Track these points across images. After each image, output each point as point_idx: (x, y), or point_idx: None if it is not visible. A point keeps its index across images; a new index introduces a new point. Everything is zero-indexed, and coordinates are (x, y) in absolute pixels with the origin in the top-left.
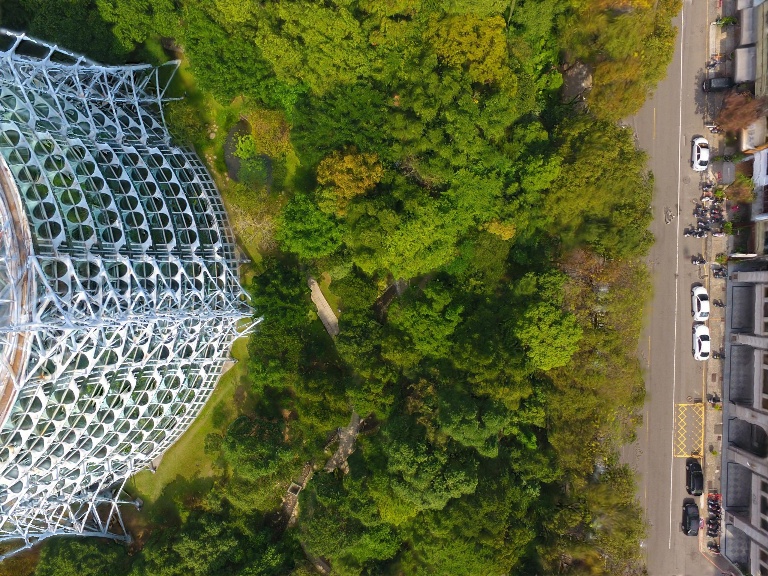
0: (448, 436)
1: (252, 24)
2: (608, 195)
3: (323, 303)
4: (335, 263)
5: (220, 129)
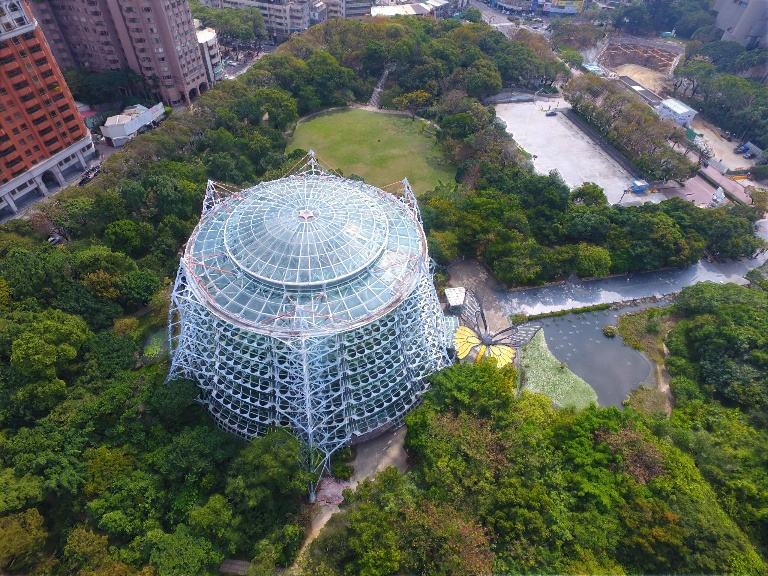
0: None
1: None
2: (5, 235)
3: None
4: None
5: (159, 364)
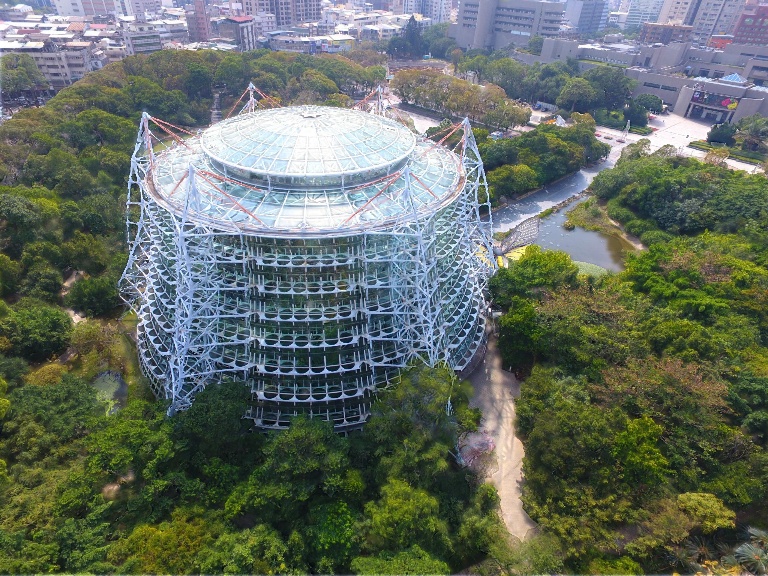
0: None
1: (6, 442)
2: None
3: (74, 318)
4: None
5: None
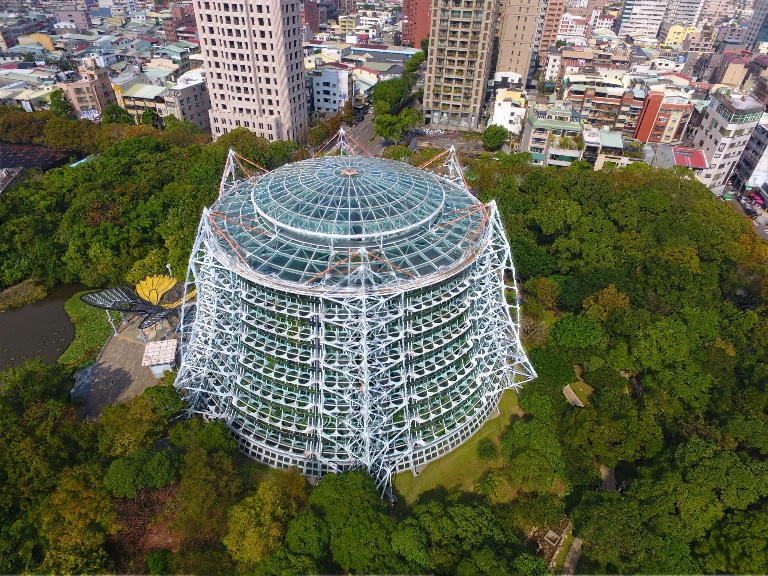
0: (735, 438)
1: None
2: None
3: (573, 396)
4: (594, 352)
5: None
